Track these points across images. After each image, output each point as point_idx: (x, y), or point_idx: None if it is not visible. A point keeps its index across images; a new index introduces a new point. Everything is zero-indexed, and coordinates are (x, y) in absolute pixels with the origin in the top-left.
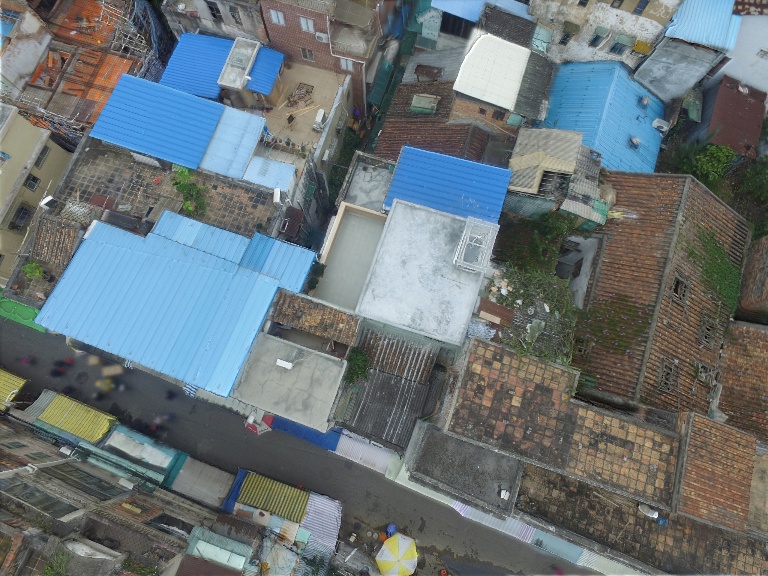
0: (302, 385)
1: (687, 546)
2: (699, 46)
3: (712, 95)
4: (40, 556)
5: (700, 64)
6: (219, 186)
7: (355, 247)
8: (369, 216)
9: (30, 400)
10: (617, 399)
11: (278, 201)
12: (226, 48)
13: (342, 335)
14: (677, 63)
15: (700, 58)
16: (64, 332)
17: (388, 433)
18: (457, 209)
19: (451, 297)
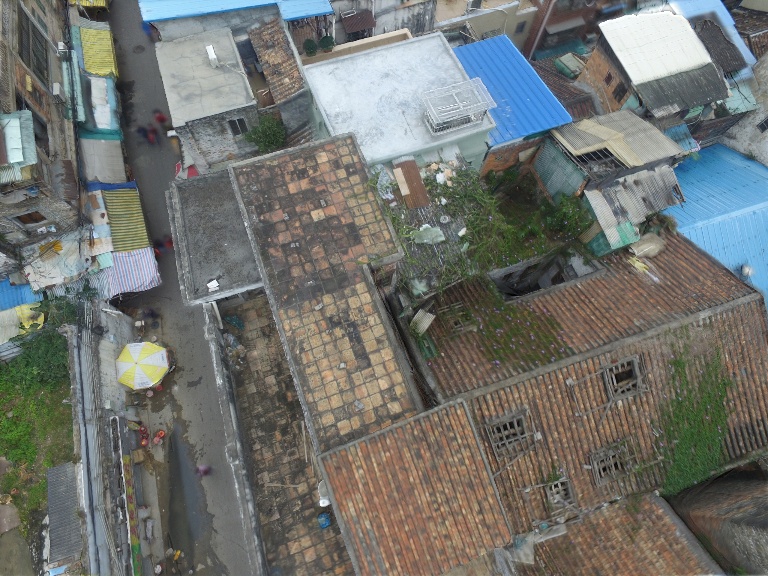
0: (205, 84)
1: None
2: None
3: None
4: None
5: None
6: None
7: None
8: None
9: None
10: (431, 381)
11: None
12: None
13: (279, 88)
14: None
15: None
16: None
17: None
18: None
19: (389, 132)
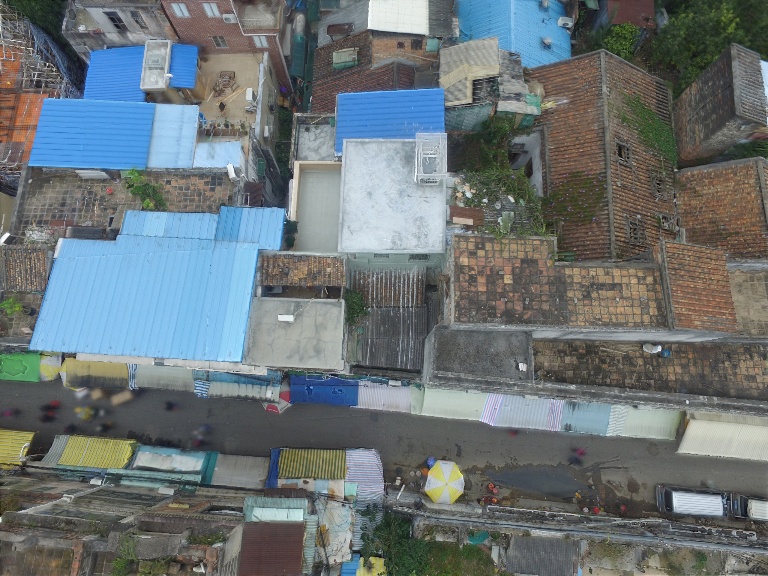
0: (308, 333)
1: (694, 369)
2: None
3: None
4: (104, 560)
5: None
6: (172, 180)
7: (320, 201)
8: (324, 169)
9: (44, 452)
10: None
11: (234, 176)
12: (139, 54)
13: (332, 278)
14: None
15: None
16: (62, 349)
17: (402, 361)
18: (404, 136)
19: (422, 212)
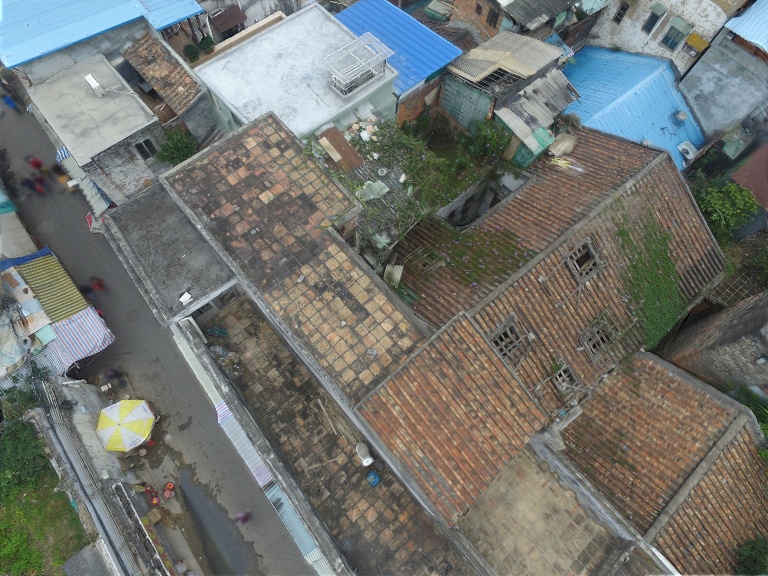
0: (97, 115)
1: (389, 536)
2: (759, 50)
3: (763, 141)
4: None
5: (757, 85)
6: None
7: None
8: None
9: None
10: None
11: None
12: None
13: (176, 99)
14: (731, 76)
15: (759, 74)
16: None
17: None
18: None
19: (302, 107)
